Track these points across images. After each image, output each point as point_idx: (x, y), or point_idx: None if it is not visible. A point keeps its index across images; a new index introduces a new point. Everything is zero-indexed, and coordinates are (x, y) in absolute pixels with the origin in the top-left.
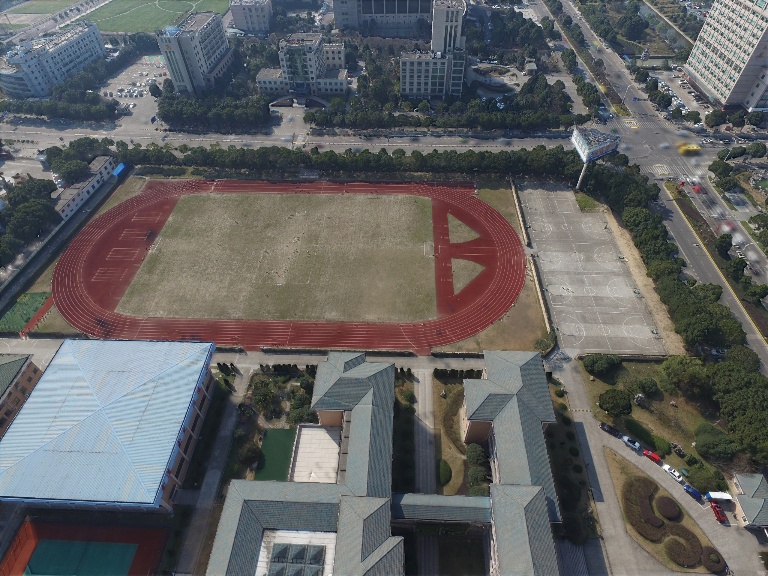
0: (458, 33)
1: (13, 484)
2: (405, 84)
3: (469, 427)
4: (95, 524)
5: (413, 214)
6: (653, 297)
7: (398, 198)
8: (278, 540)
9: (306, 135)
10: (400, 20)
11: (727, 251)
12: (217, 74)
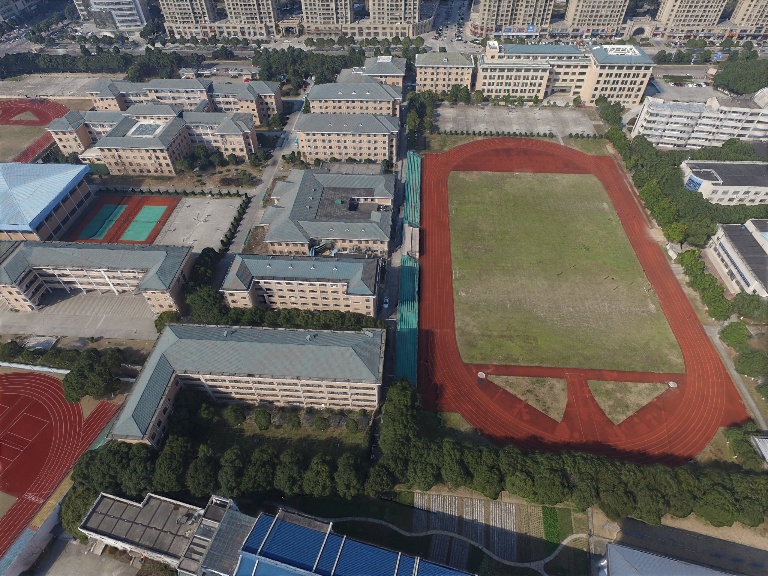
0: None
1: (36, 209)
2: None
3: (119, 106)
4: (82, 221)
5: None
6: (96, 75)
7: None
8: (130, 134)
9: None
10: None
11: None
12: None
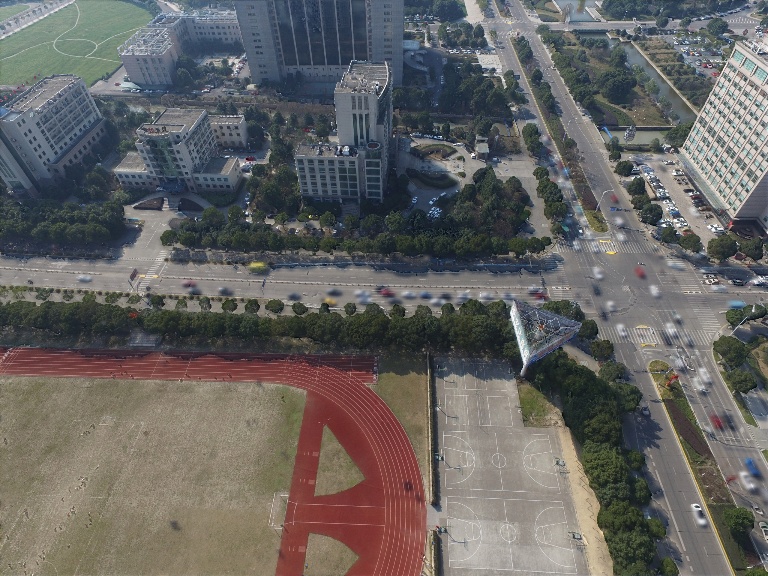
0: (371, 123)
1: None
2: (306, 185)
3: None
4: None
5: (272, 427)
6: None
7: (259, 391)
8: None
9: (164, 261)
10: (332, 73)
11: (745, 535)
12: (71, 160)
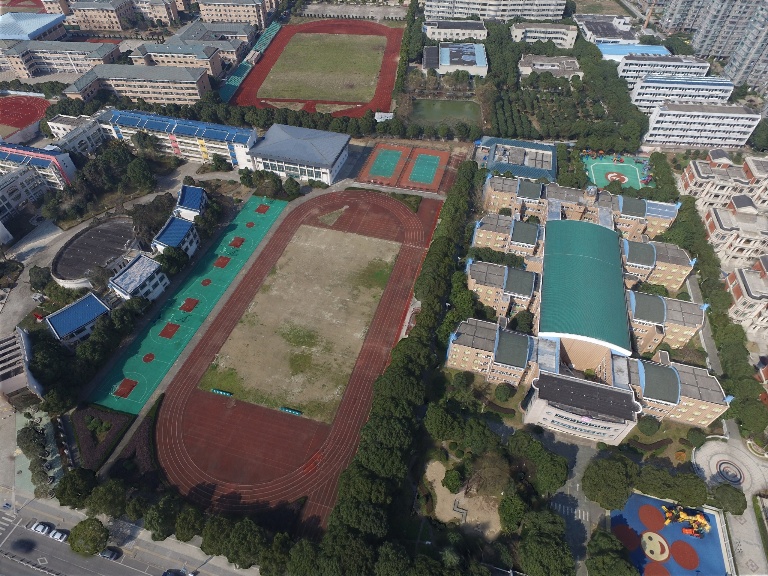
0: None
1: None
2: None
3: None
4: None
5: None
6: None
7: None
8: None
9: None
10: None
11: None
12: None
